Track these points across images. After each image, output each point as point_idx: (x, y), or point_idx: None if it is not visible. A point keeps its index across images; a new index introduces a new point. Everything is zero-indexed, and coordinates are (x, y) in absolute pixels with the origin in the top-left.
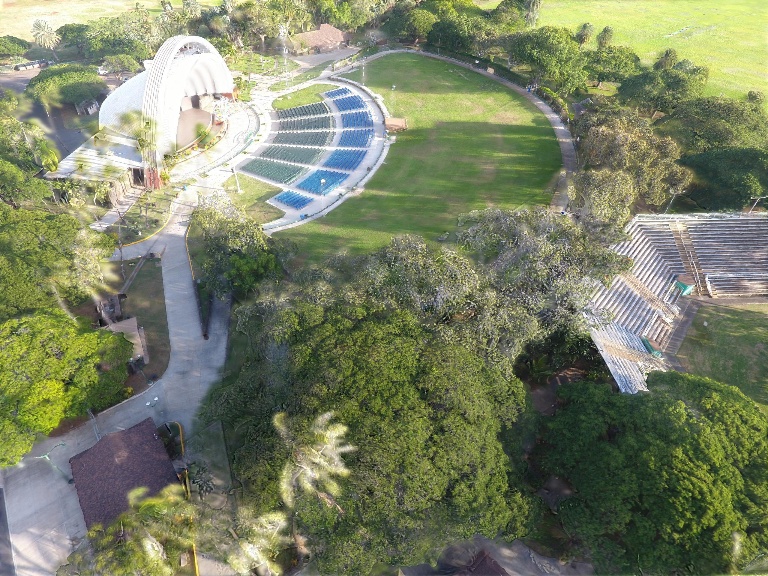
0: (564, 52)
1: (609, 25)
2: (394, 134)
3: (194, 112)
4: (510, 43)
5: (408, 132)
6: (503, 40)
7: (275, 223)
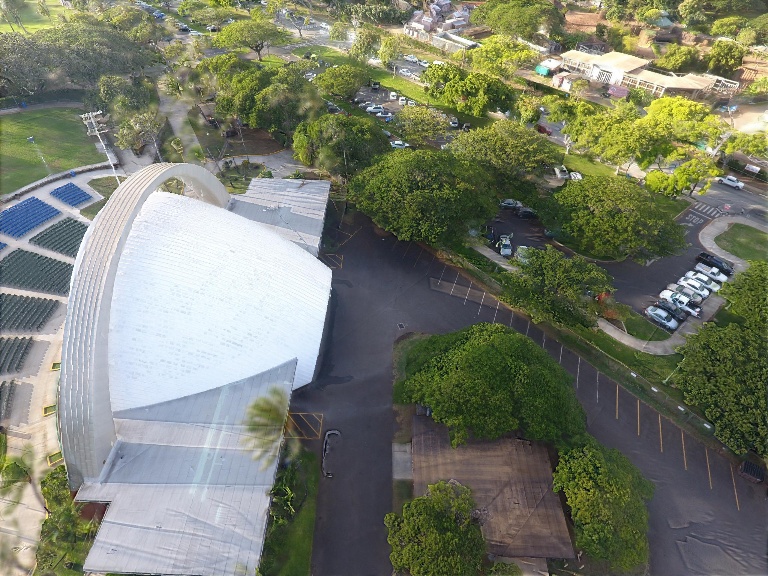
0: None
1: None
2: None
3: None
4: None
5: None
6: None
7: (102, 175)
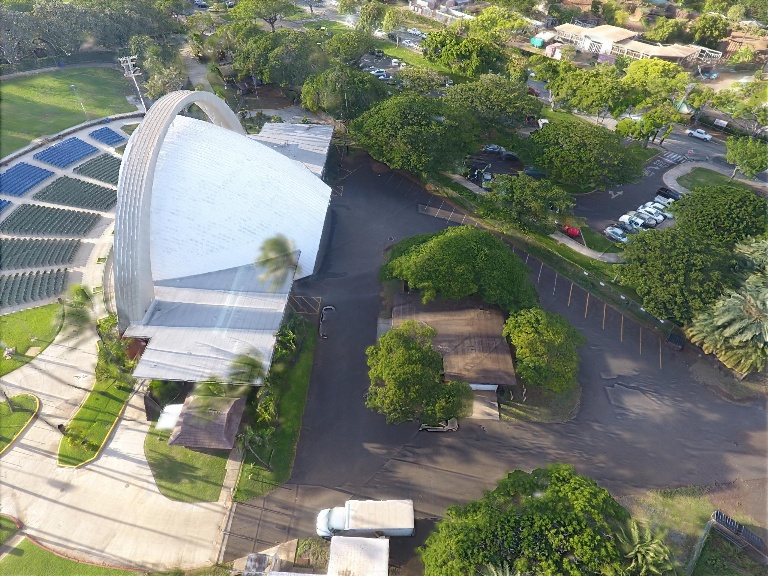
0: None
1: None
2: None
3: None
4: None
5: None
6: None
7: (133, 122)
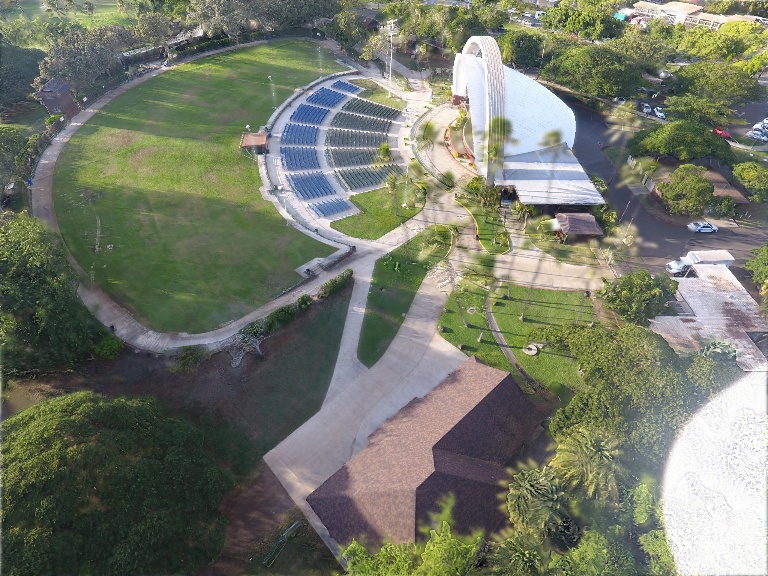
0: None
1: None
2: None
3: None
4: None
5: None
6: (1, 175)
7: (353, 78)
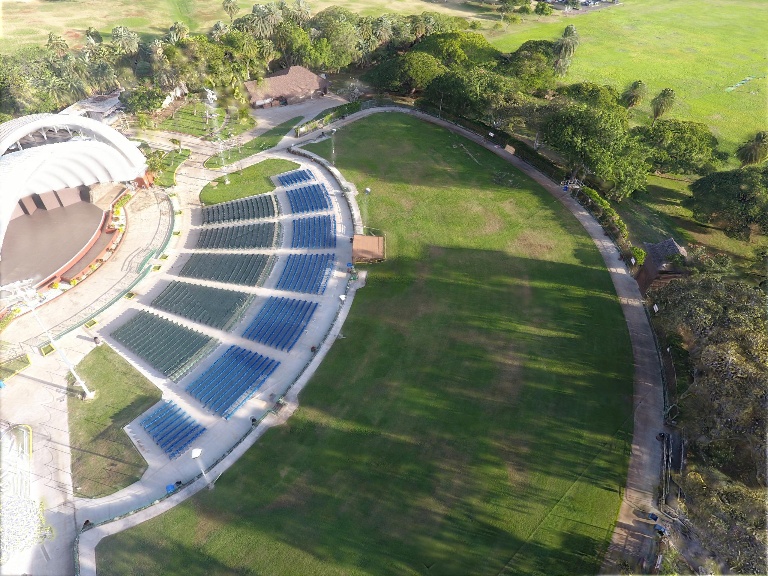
0: (621, 142)
1: (653, 71)
2: (364, 267)
3: (80, 209)
4: (540, 120)
5: (385, 266)
6: (530, 113)
7: (120, 498)
